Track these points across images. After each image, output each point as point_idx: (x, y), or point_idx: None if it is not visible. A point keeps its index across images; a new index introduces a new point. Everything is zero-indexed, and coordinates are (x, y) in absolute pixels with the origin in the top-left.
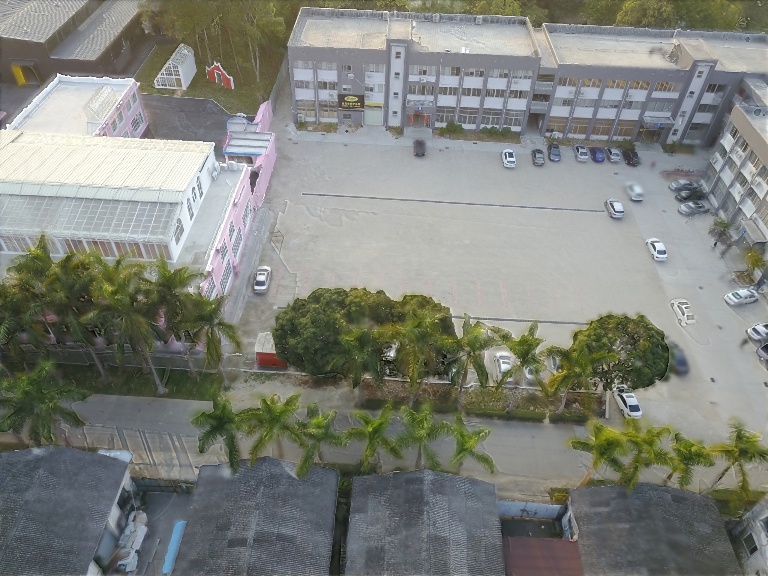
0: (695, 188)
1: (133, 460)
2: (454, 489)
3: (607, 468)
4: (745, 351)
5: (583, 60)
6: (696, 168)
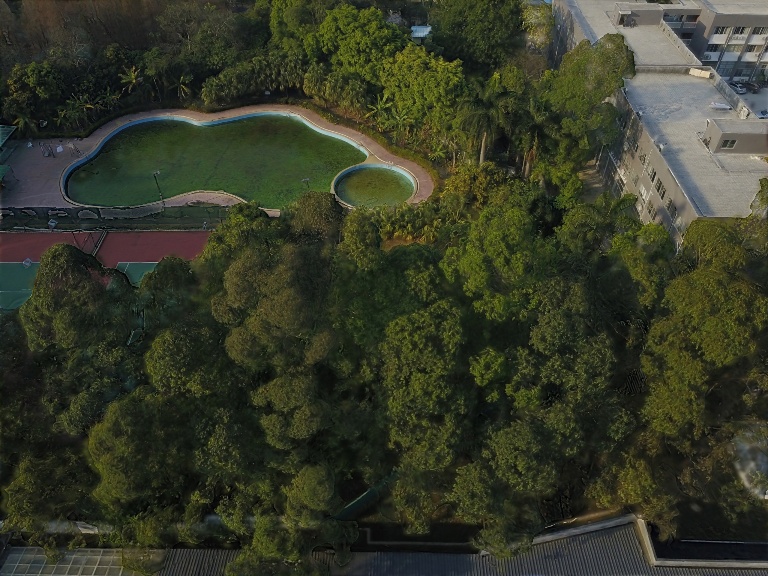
0: None
1: None
2: None
3: None
4: None
5: (662, 59)
6: None
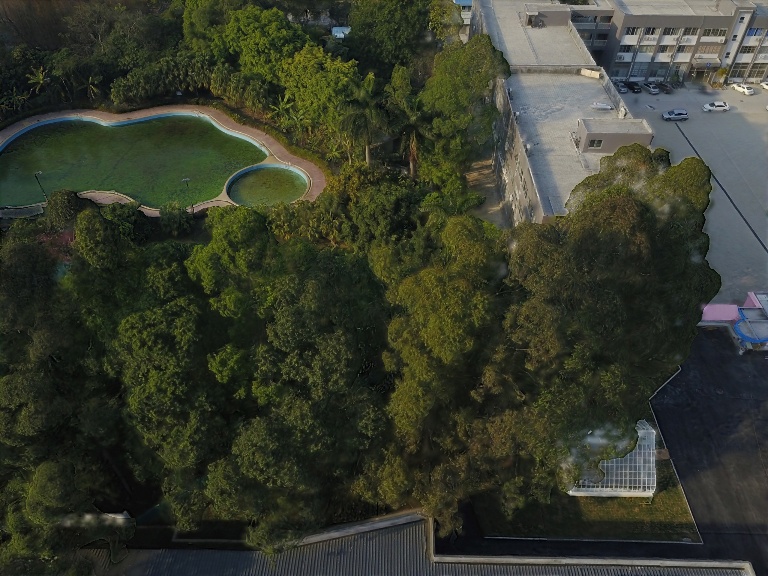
0: None
1: None
2: None
3: None
4: None
5: (561, 59)
6: None
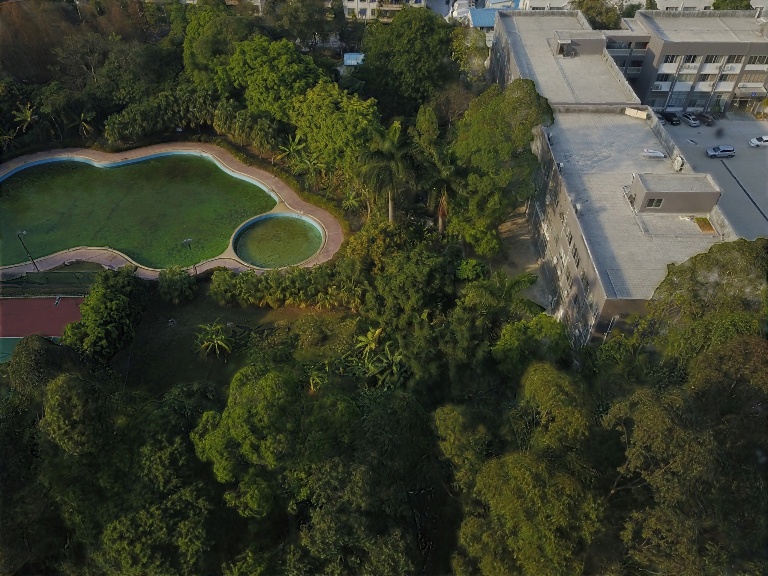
0: None
1: None
2: None
3: None
4: None
5: (599, 95)
6: None
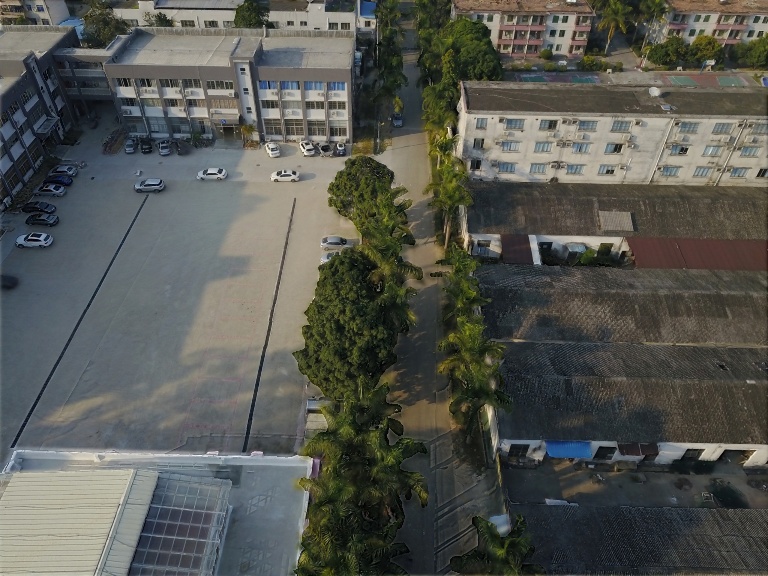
0: (137, 140)
1: (472, 549)
2: (487, 277)
3: (425, 234)
4: (321, 162)
5: None
6: (107, 134)
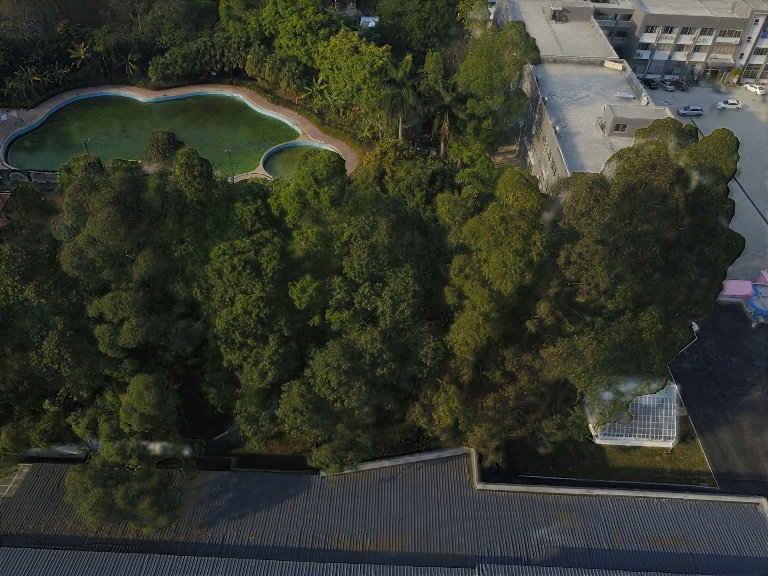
0: None
1: None
2: None
3: None
4: None
5: (584, 52)
6: None
